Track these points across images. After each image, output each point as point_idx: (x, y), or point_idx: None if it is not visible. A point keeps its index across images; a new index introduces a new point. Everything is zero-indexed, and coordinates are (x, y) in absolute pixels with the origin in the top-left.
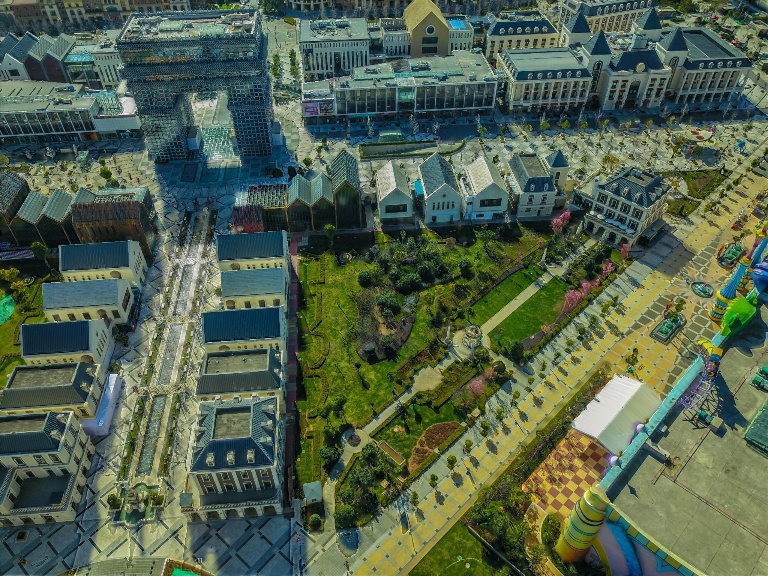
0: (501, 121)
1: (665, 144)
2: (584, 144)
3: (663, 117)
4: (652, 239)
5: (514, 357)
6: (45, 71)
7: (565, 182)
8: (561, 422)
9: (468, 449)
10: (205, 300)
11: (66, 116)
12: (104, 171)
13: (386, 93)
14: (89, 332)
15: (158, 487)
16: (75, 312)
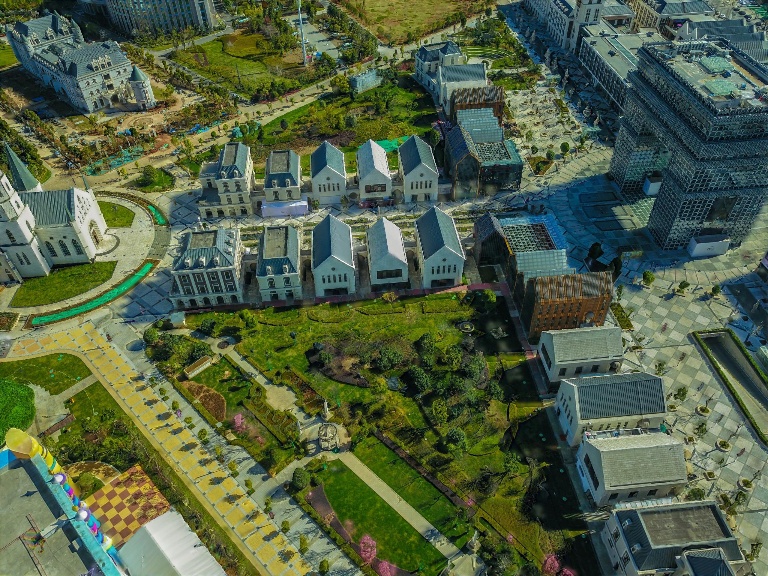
0: None
1: None
2: None
3: None
4: None
5: None
6: None
7: None
8: (195, 513)
9: (191, 426)
10: None
11: None
12: (564, 143)
13: None
14: (321, 170)
15: None
16: None
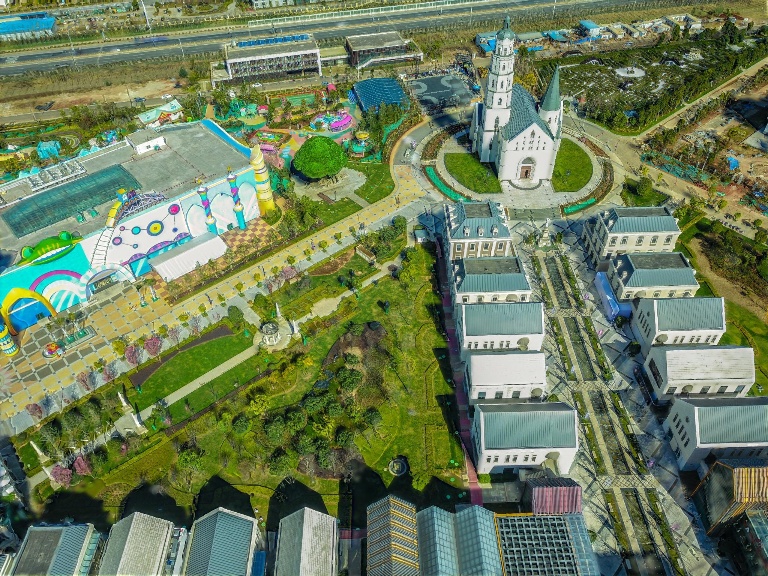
0: None
1: None
2: None
3: None
4: None
5: None
6: None
7: None
8: (231, 267)
9: (309, 258)
10: None
11: None
12: None
13: None
14: None
15: None
16: None
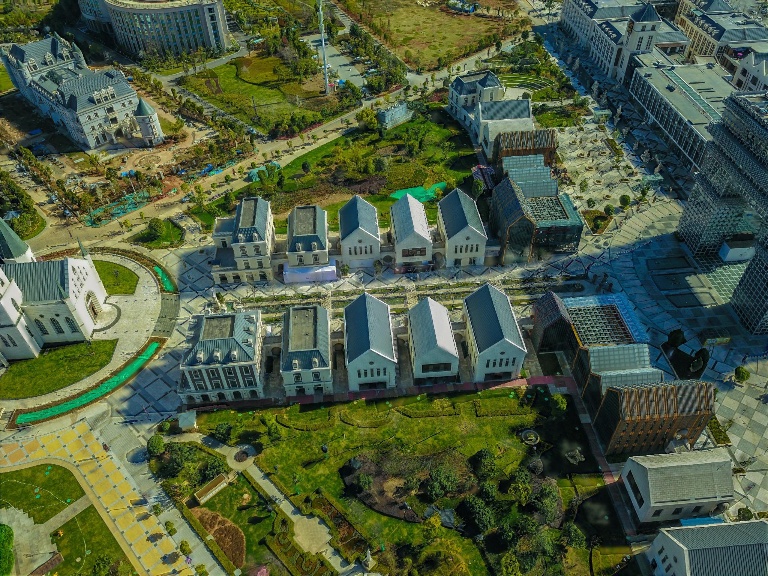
0: None
1: None
2: None
3: None
4: None
5: None
6: None
7: None
8: None
9: (203, 574)
10: None
11: (698, 142)
12: (624, 196)
13: None
14: (352, 232)
15: None
16: None
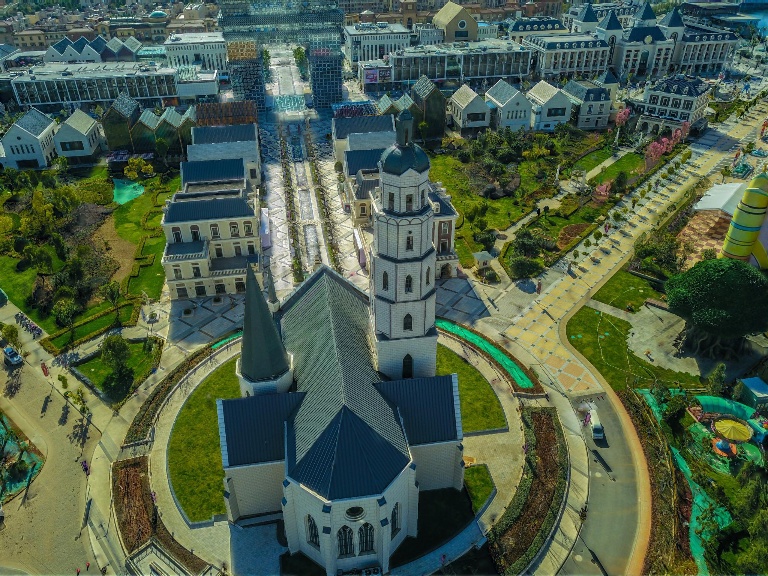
0: None
1: None
2: None
3: None
4: (700, 132)
5: (619, 189)
6: None
7: None
8: (680, 216)
9: (606, 235)
10: (323, 177)
11: (152, 81)
12: None
13: (437, 61)
14: (244, 167)
15: None
16: None
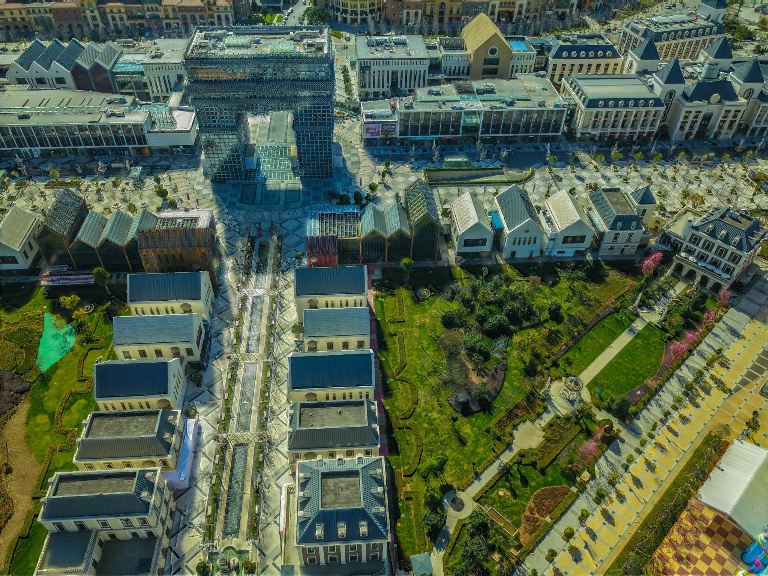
0: (568, 149)
1: (742, 180)
2: (658, 177)
3: (738, 151)
4: (746, 284)
5: (619, 413)
6: (92, 80)
7: (650, 219)
8: (680, 491)
9: None
10: (279, 336)
11: (119, 129)
12: (161, 190)
13: (452, 116)
14: (168, 374)
15: (248, 552)
16: (147, 349)
